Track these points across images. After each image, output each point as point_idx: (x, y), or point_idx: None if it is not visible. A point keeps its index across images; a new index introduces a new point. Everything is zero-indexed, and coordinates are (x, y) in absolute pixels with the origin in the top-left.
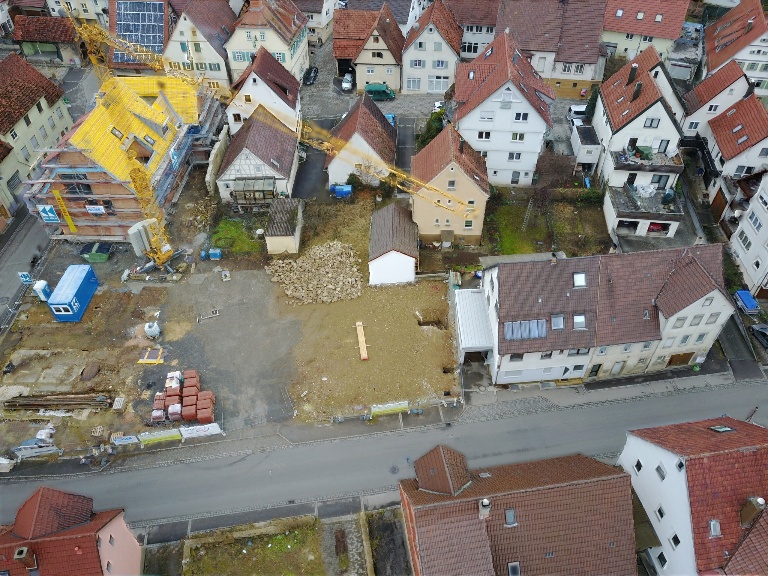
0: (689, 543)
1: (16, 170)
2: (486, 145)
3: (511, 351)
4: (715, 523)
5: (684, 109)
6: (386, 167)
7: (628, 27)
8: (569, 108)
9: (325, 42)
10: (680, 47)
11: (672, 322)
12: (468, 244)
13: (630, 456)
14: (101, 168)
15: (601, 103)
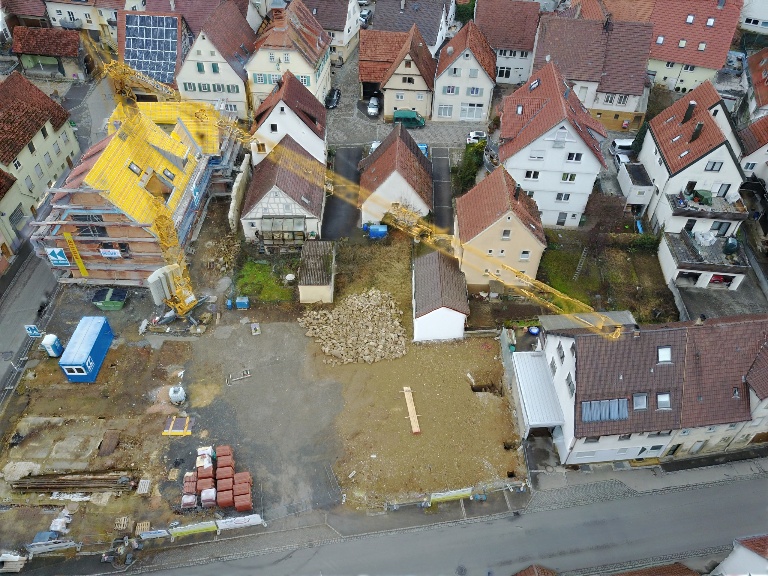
0: None
1: (19, 203)
2: (533, 185)
3: (589, 434)
4: None
5: (742, 149)
6: (425, 206)
7: (669, 55)
8: (613, 142)
9: (346, 61)
10: (722, 77)
11: (765, 402)
12: (518, 295)
13: (737, 567)
14: (119, 210)
15: (652, 140)
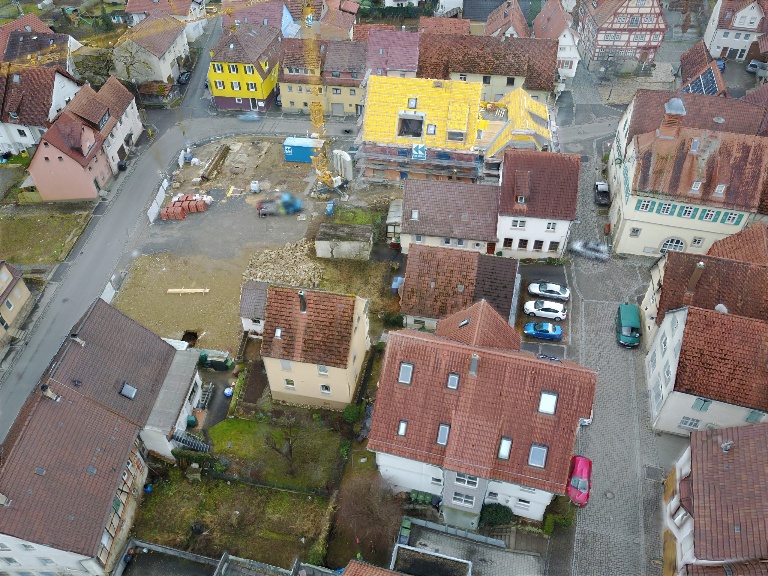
0: None
1: None
2: None
3: None
4: None
5: None
6: None
7: None
8: None
9: None
10: None
11: None
12: None
13: None
14: (365, 105)
15: None
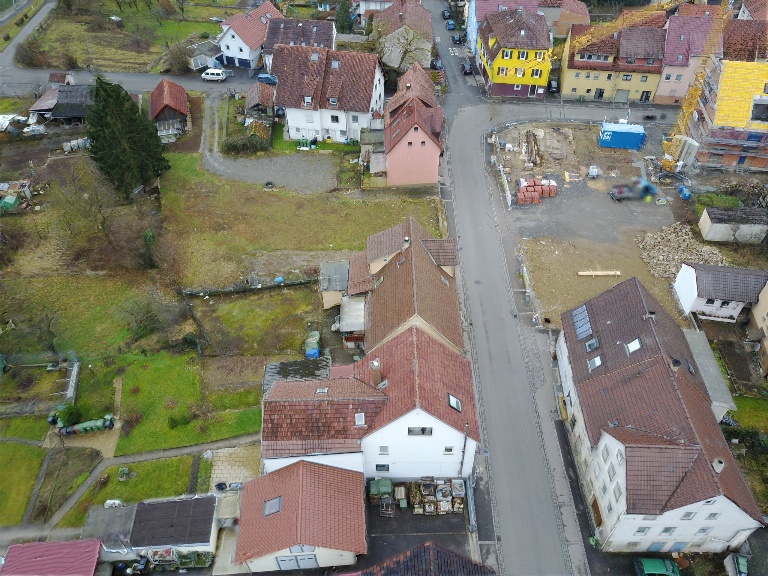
0: None
1: None
2: None
3: (564, 321)
4: (376, 360)
5: None
6: None
7: None
8: None
9: None
10: None
11: None
12: (762, 365)
13: None
14: (717, 90)
15: None
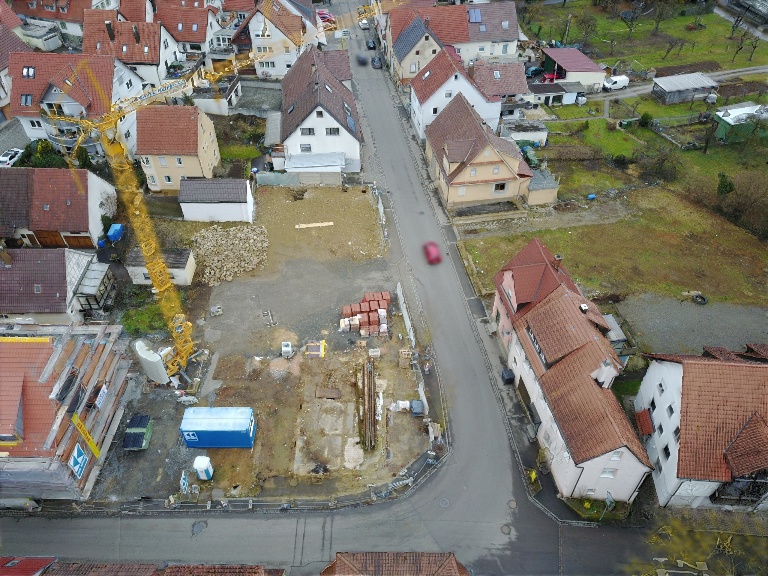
0: (478, 99)
1: None
2: (127, 124)
3: (360, 137)
4: None
5: None
6: (112, 189)
7: None
8: None
9: None
10: None
11: None
12: None
13: (428, 114)
14: None
15: None
